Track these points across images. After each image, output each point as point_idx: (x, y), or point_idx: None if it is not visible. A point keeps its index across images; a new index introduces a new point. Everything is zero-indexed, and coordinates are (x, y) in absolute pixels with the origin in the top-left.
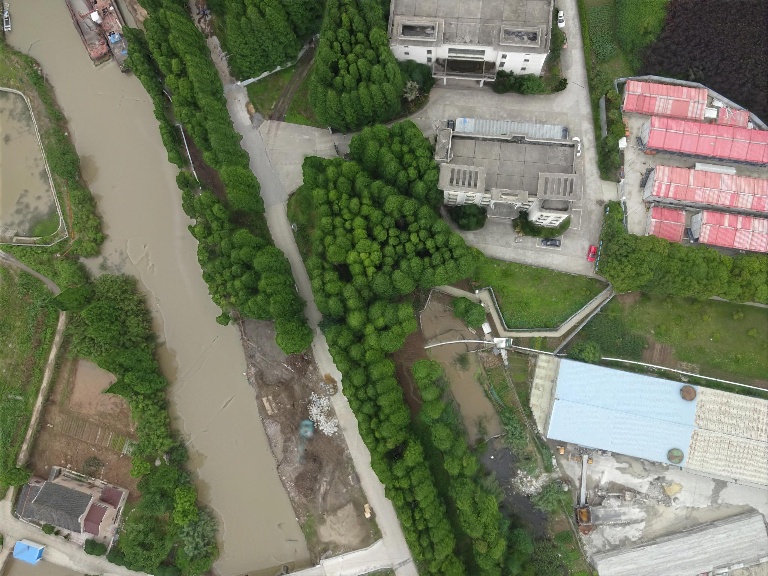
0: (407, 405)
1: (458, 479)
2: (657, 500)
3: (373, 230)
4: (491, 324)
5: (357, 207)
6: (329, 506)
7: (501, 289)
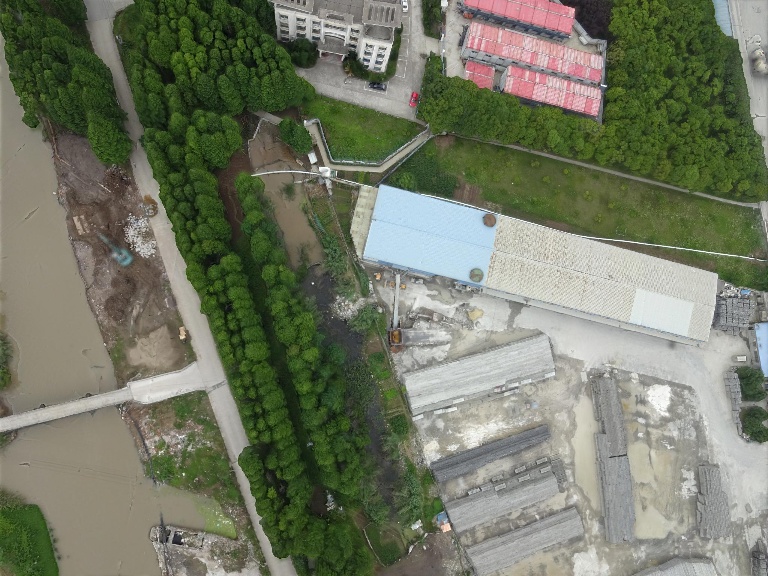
0: (229, 223)
1: (274, 286)
2: (461, 324)
3: (200, 33)
4: (318, 156)
5: (183, 5)
6: (141, 329)
7: (329, 124)
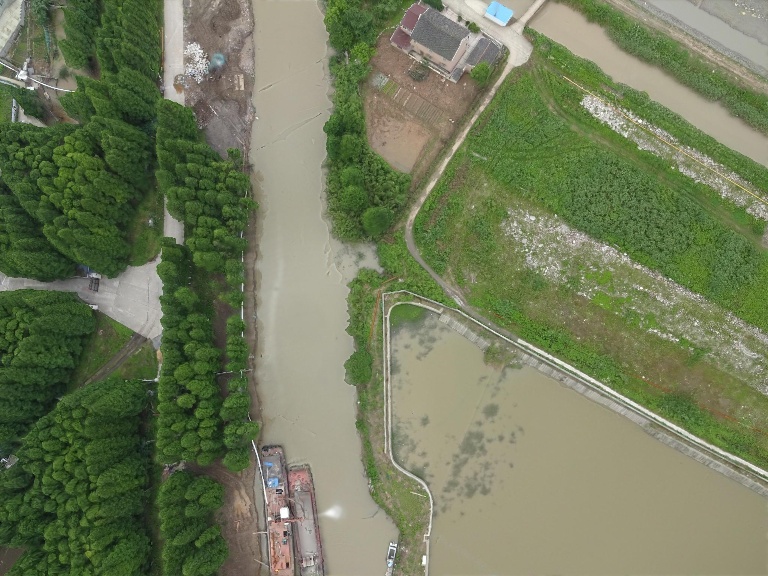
0: None
1: None
2: None
3: (54, 175)
4: None
5: None
6: None
7: (8, 121)
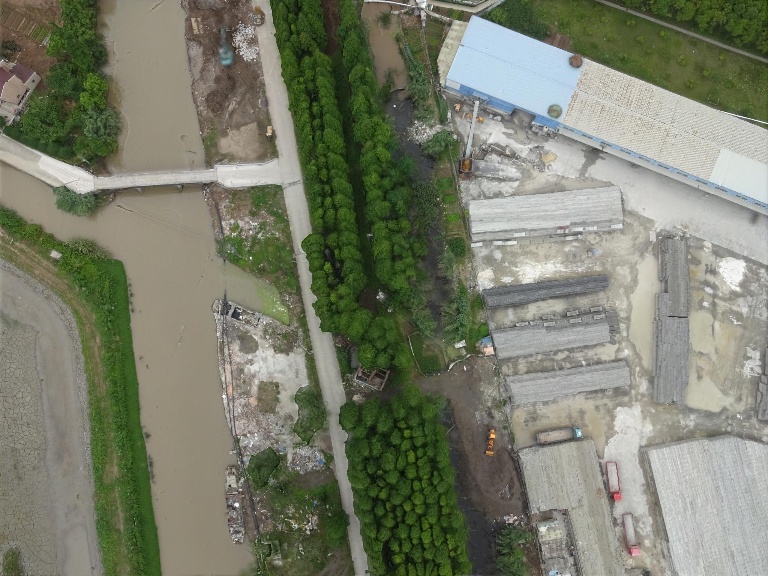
0: None
1: (359, 87)
2: (533, 165)
3: None
4: None
5: None
6: (234, 123)
7: None
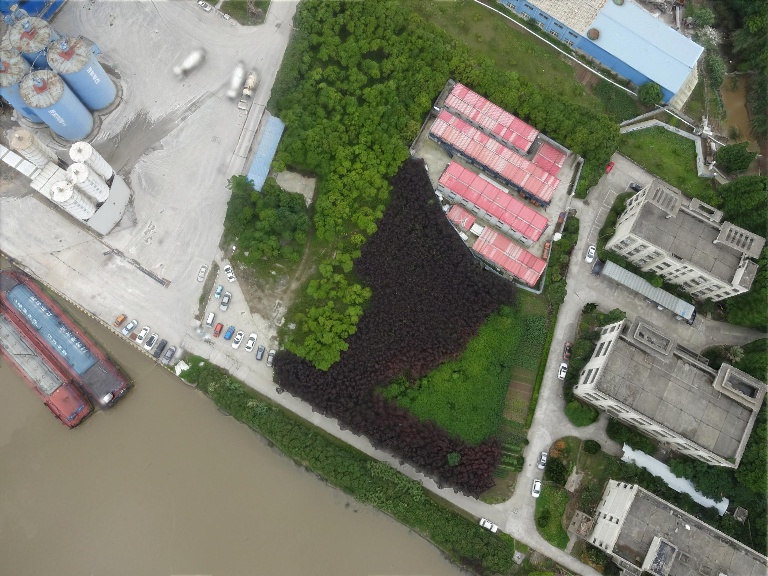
0: None
1: None
2: None
3: None
4: (705, 150)
5: None
6: None
7: (691, 171)
